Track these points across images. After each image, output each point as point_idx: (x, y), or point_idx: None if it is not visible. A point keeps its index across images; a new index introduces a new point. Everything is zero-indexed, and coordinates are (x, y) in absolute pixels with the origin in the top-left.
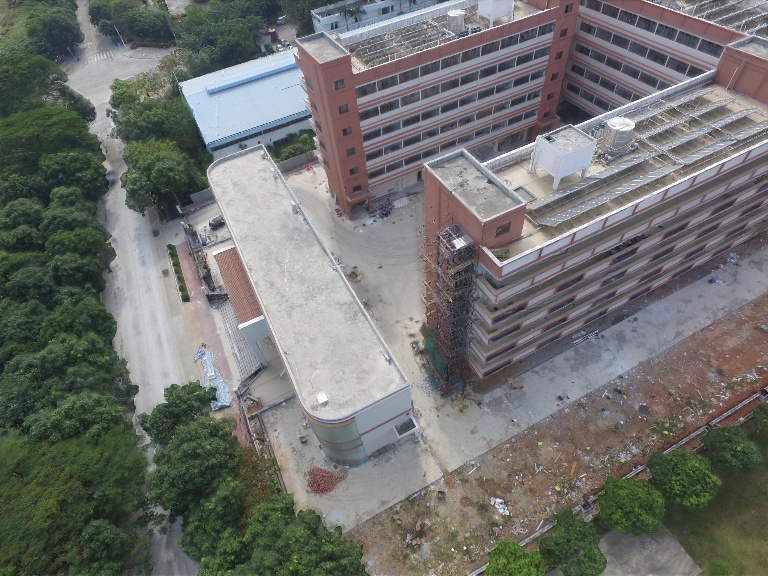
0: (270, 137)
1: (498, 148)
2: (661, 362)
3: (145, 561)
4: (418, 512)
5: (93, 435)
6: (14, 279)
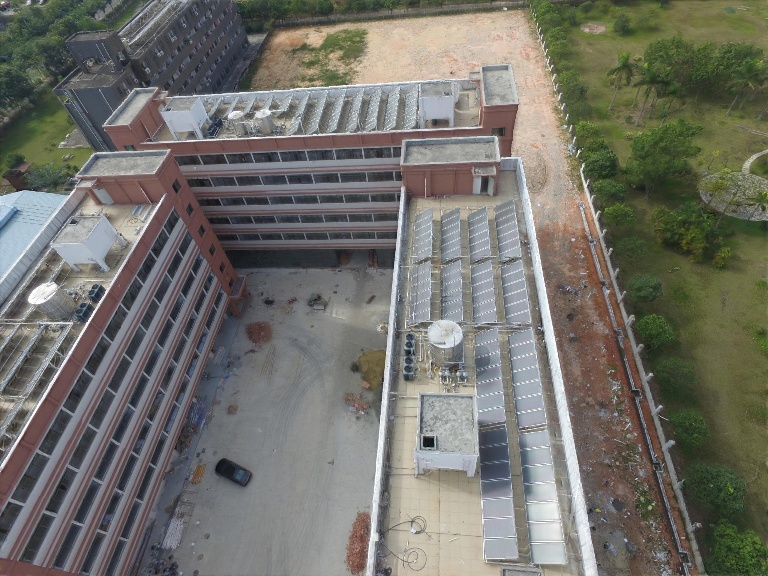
0: None
1: (211, 351)
2: None
3: None
4: None
5: None
6: None
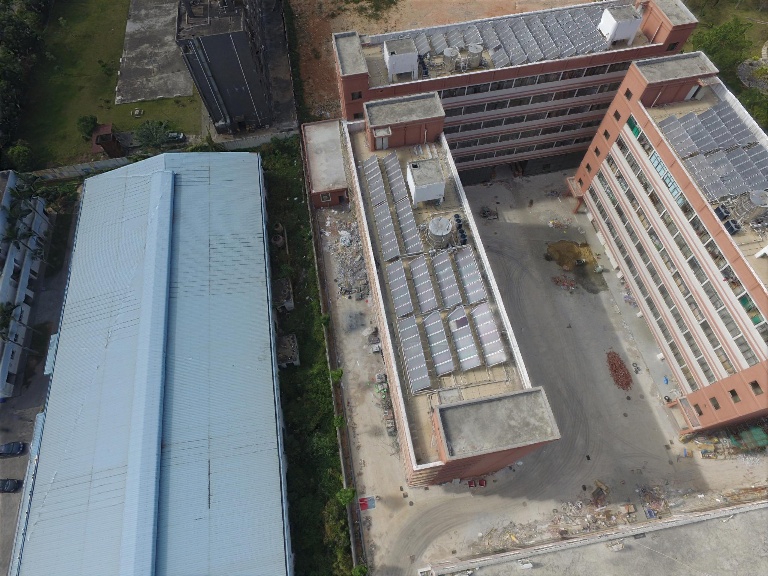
0: None
1: None
2: None
3: None
4: None
5: None
6: None
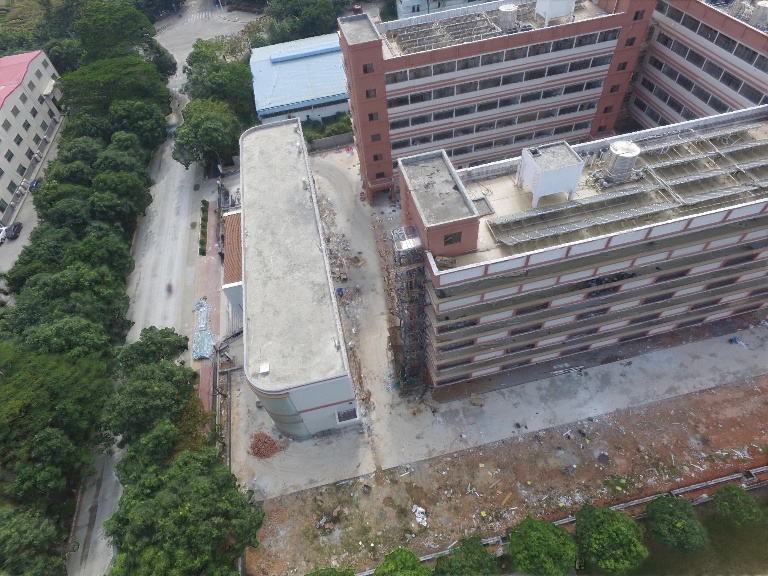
0: (319, 112)
1: None
2: (641, 414)
3: (89, 475)
4: (340, 499)
5: (74, 355)
6: (56, 207)
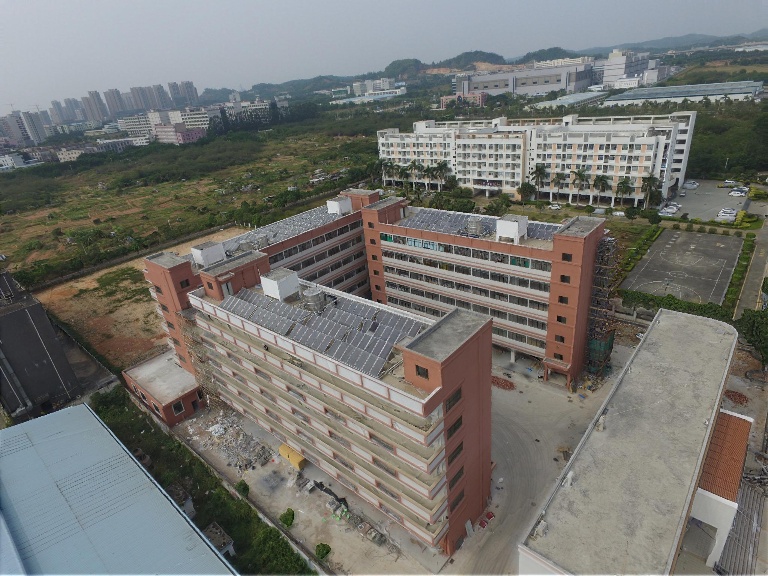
0: None
1: None
2: None
3: None
4: None
5: None
6: None
